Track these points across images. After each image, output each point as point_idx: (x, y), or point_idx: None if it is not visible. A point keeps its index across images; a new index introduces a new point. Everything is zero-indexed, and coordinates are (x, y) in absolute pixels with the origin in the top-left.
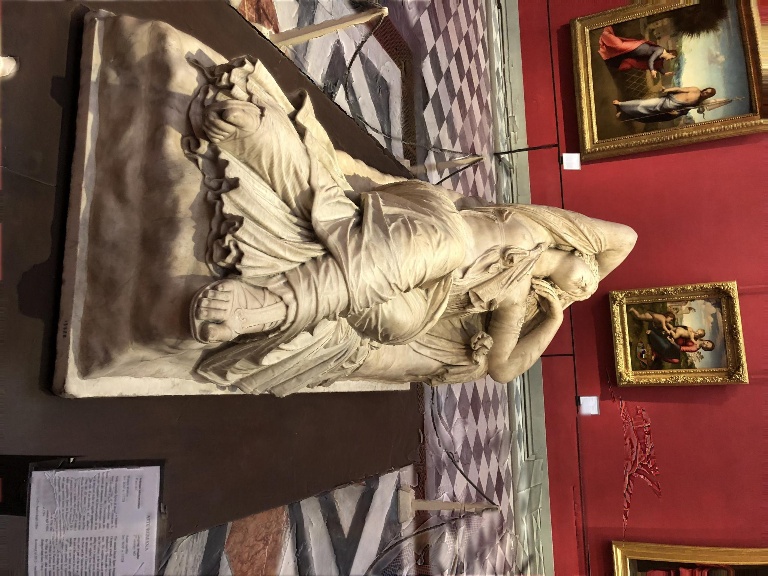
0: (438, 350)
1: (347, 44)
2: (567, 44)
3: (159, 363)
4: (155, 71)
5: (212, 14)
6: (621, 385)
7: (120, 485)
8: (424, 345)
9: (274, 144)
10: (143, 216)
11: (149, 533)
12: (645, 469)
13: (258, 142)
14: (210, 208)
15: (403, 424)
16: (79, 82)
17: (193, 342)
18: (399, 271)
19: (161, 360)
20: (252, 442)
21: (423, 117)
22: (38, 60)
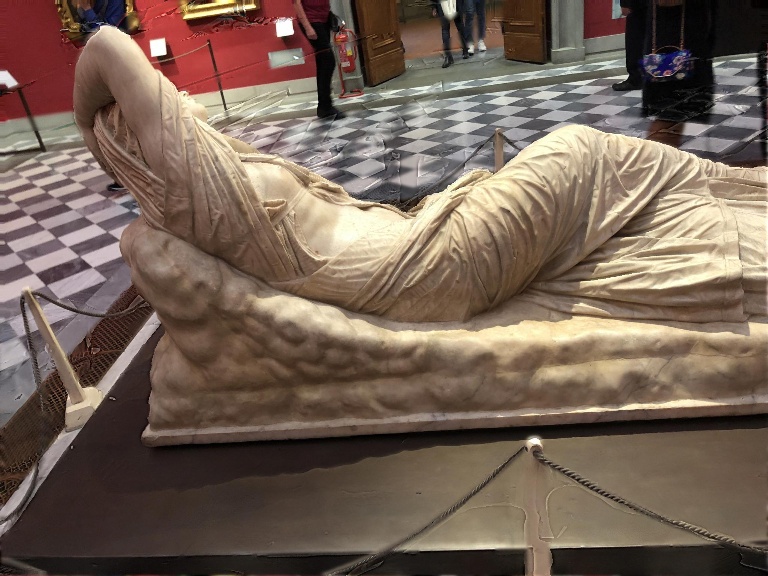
0: None
1: None
2: None
3: None
4: None
5: (738, 510)
6: None
7: None
8: None
9: None
10: None
11: None
12: (237, 7)
13: None
14: None
15: None
16: None
17: None
18: None
19: None
20: None
21: None
22: None
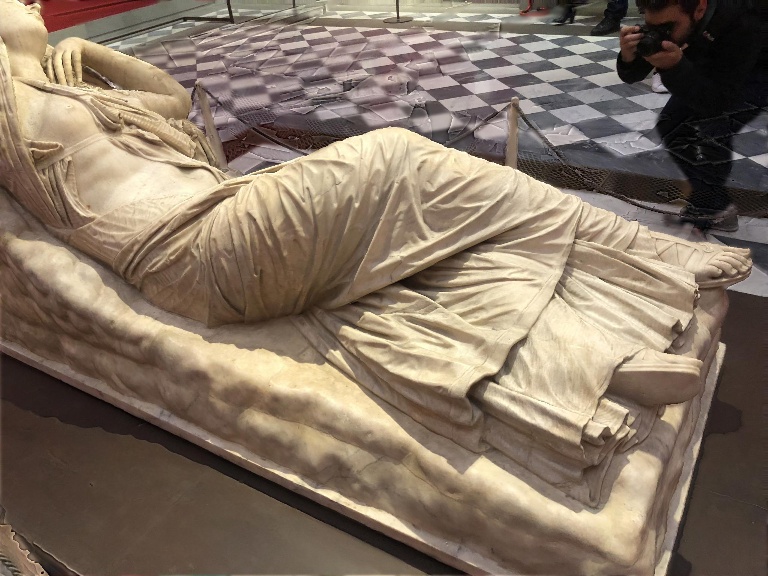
0: None
1: None
2: None
3: None
4: None
5: None
6: None
7: None
8: None
9: None
10: None
11: None
12: None
13: None
14: None
15: None
16: None
17: None
18: None
19: None
20: None
21: None
22: None
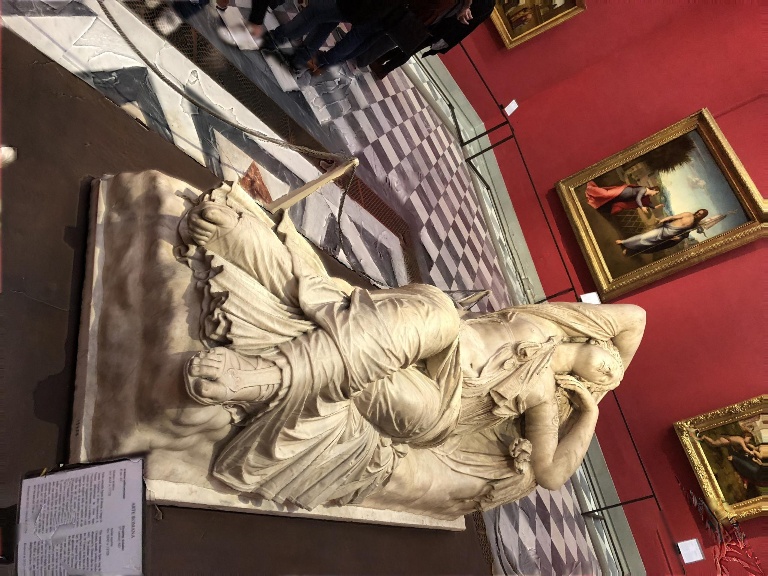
0: (478, 466)
1: (341, 217)
2: (557, 205)
3: (172, 460)
4: (148, 204)
5: (206, 185)
6: (685, 472)
7: (106, 480)
8: (462, 463)
9: (254, 240)
10: (143, 315)
11: (135, 520)
12: (735, 550)
13: (239, 238)
14: (200, 294)
15: (468, 572)
16: (87, 228)
17: (194, 411)
18: (390, 337)
19: (173, 456)
20: (288, 571)
21: (430, 277)
22: (52, 214)
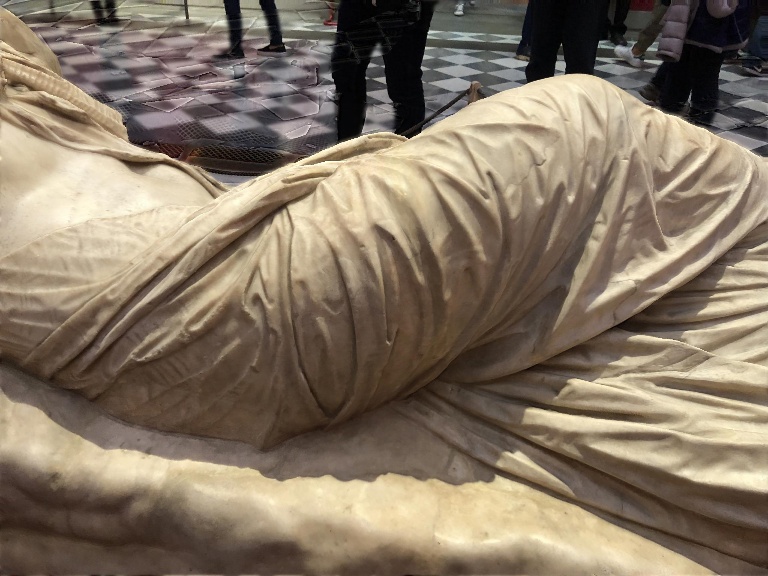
0: None
1: None
2: None
3: None
4: None
5: None
6: None
7: None
8: None
9: None
10: None
11: None
12: None
13: None
14: None
15: None
16: None
17: None
18: None
19: None
20: None
21: None
22: None
